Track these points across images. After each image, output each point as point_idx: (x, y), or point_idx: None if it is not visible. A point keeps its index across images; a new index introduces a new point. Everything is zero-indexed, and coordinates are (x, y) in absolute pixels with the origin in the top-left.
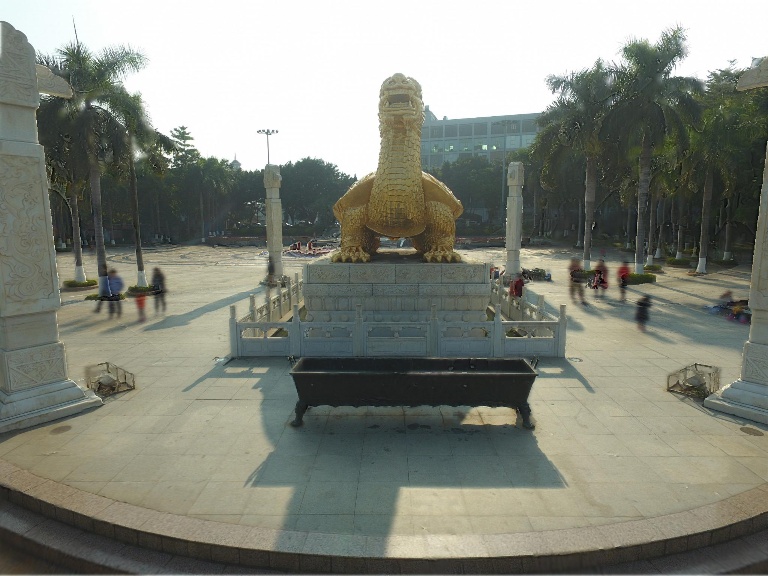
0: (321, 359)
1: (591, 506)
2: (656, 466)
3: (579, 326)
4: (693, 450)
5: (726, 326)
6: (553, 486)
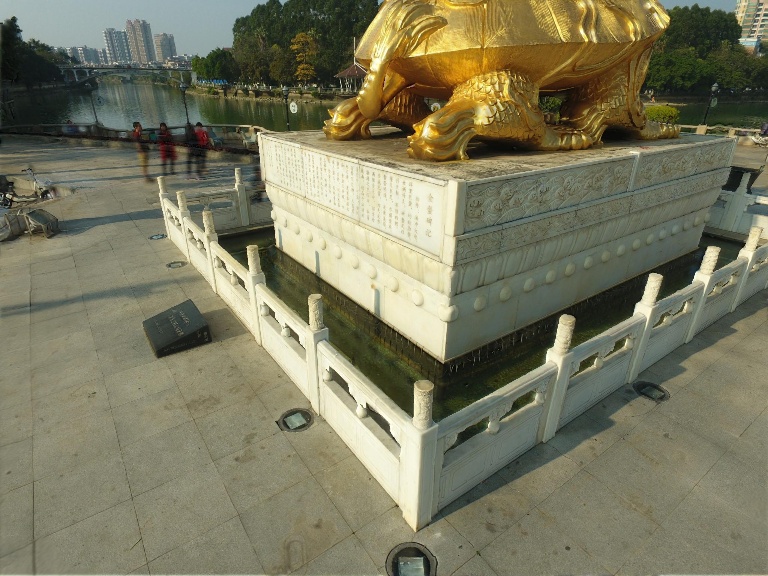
0: (737, 171)
1: None
2: None
3: None
4: None
5: None
6: None
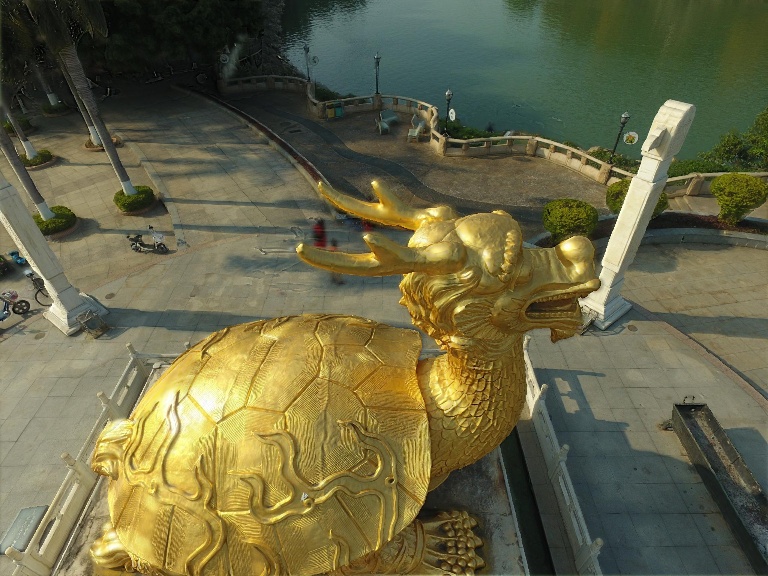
0: None
1: (767, 424)
2: (705, 383)
3: (403, 325)
4: (675, 361)
5: (394, 241)
6: (759, 435)
